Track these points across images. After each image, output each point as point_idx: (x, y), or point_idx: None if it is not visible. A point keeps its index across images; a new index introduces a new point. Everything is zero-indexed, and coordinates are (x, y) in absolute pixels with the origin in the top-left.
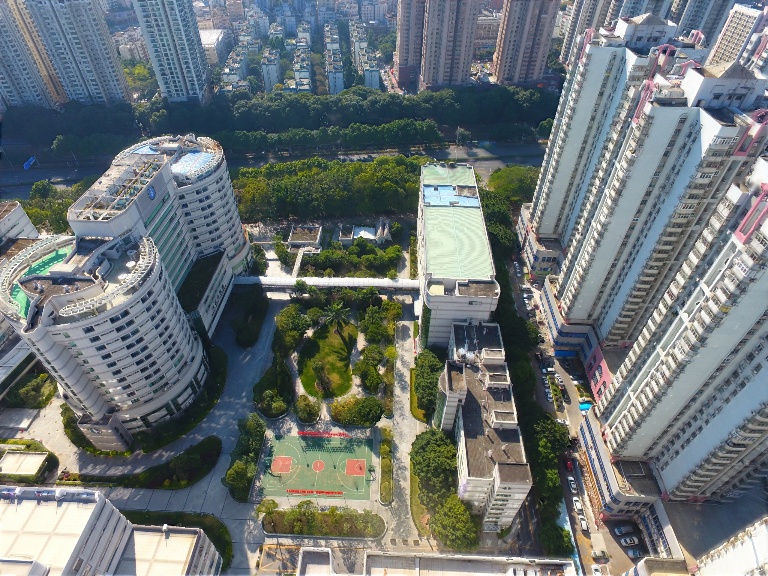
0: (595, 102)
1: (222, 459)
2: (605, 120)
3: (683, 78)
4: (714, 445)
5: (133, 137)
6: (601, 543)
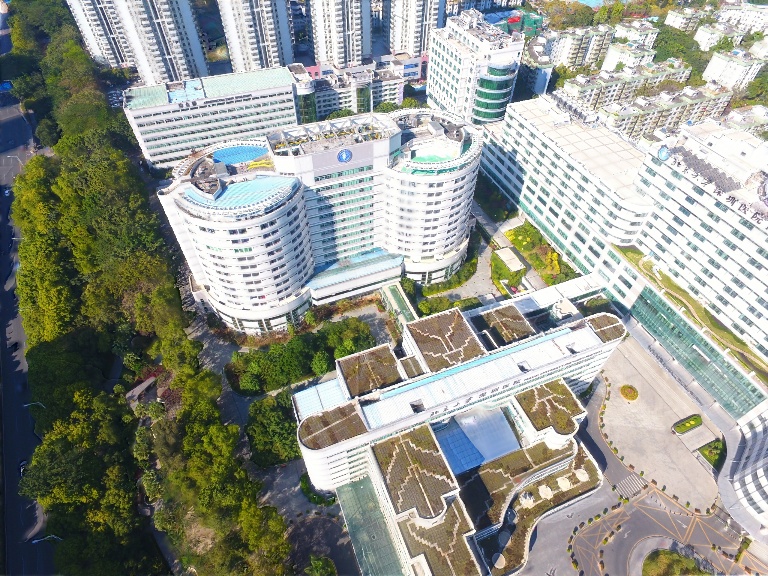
0: None
1: None
2: None
3: None
4: (369, 13)
5: None
6: None
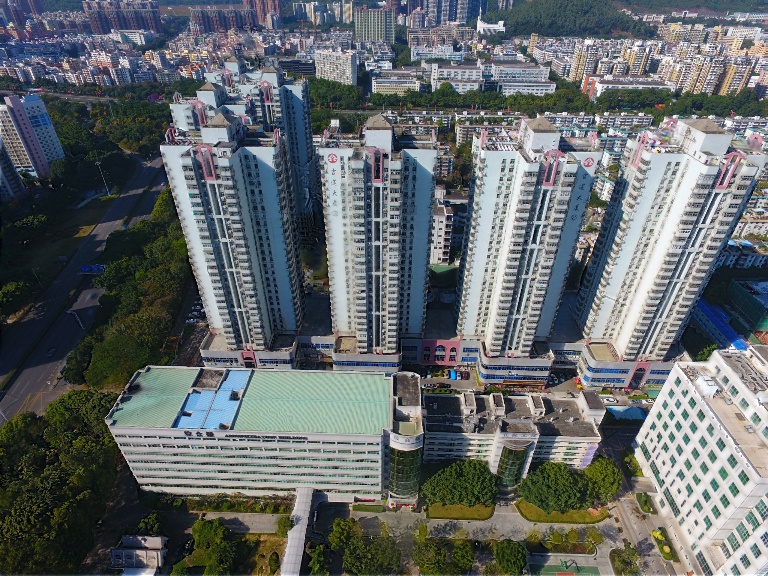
0: (247, 204)
1: None
2: (265, 212)
3: (336, 143)
4: (560, 288)
5: None
6: (561, 394)
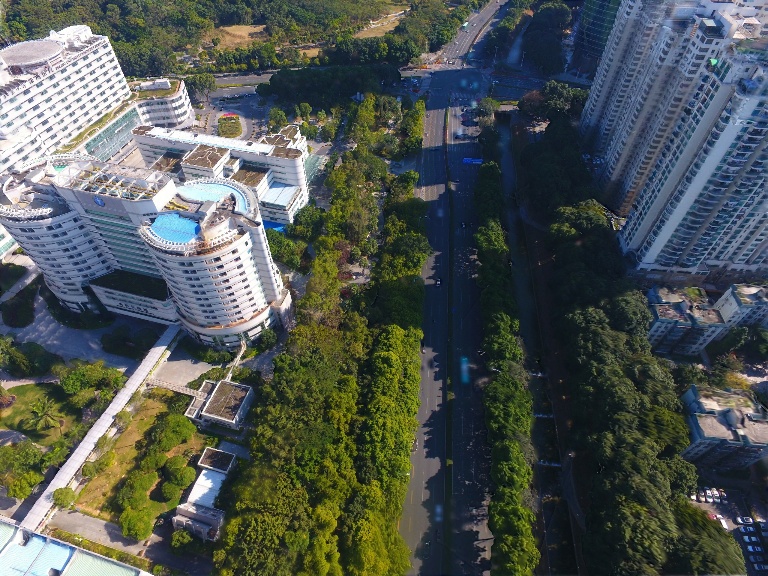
0: None
1: (7, 328)
2: None
3: None
4: None
5: (493, 215)
6: None
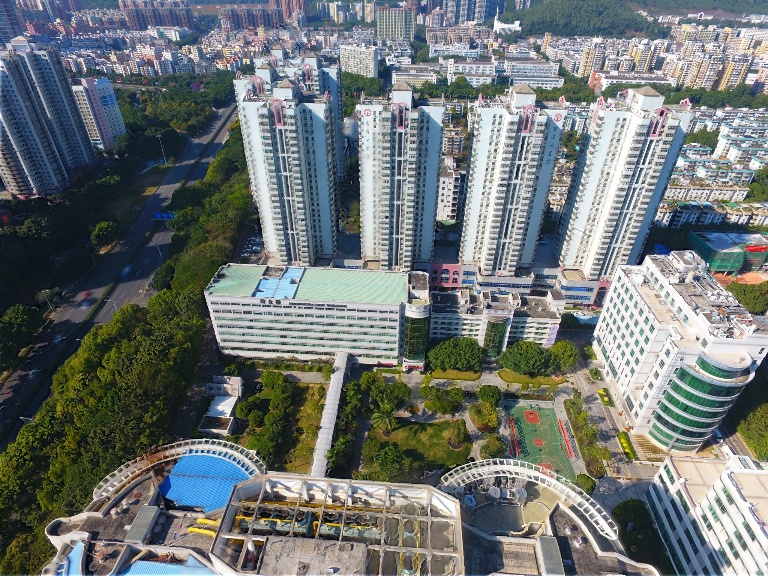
0: (303, 147)
1: None
2: (315, 155)
3: (370, 102)
4: (539, 221)
5: None
6: None
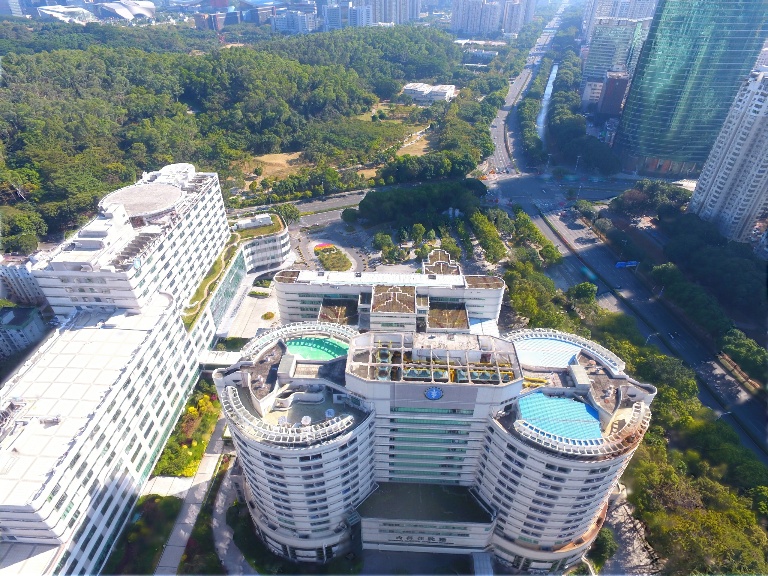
0: None
1: None
2: None
3: None
4: None
5: (729, 321)
6: None
